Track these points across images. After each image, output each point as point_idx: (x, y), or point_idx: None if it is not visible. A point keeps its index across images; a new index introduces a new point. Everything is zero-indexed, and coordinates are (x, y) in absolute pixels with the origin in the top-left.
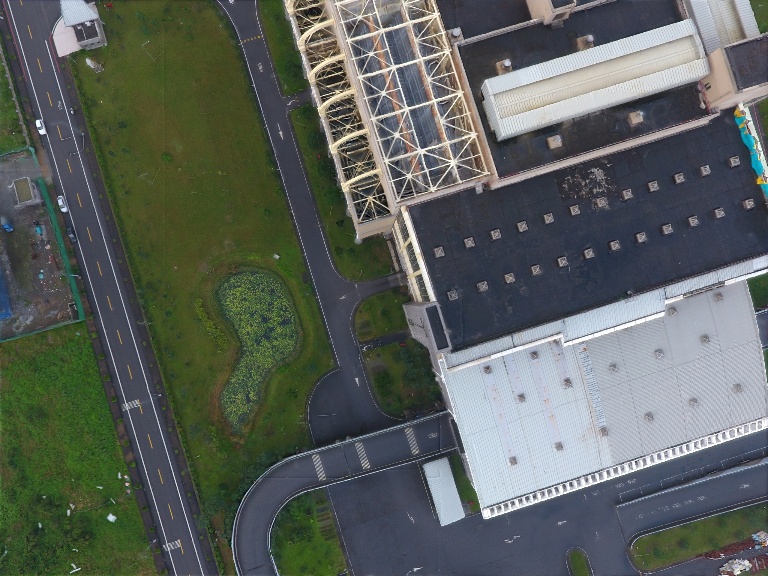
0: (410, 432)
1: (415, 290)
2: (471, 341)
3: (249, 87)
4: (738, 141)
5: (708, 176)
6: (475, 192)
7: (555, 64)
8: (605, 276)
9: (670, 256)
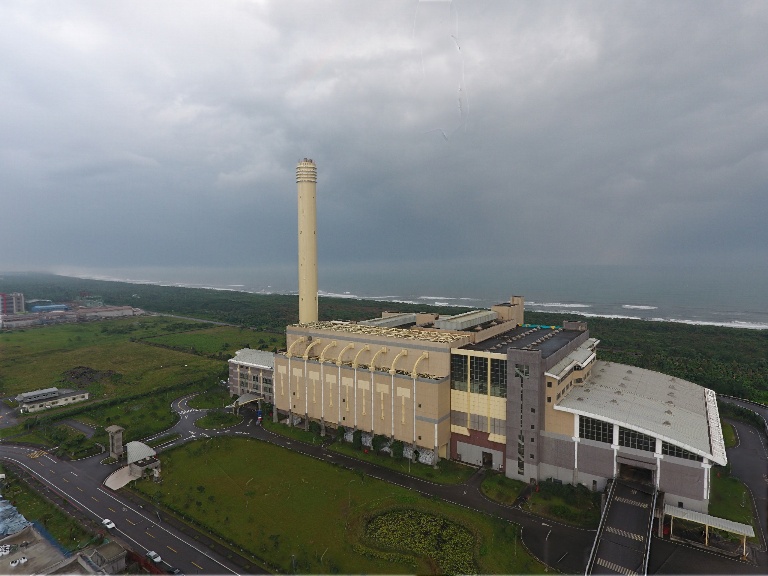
0: (620, 499)
1: (499, 417)
2: None
3: None
4: None
5: None
6: None
7: None
8: None
9: None
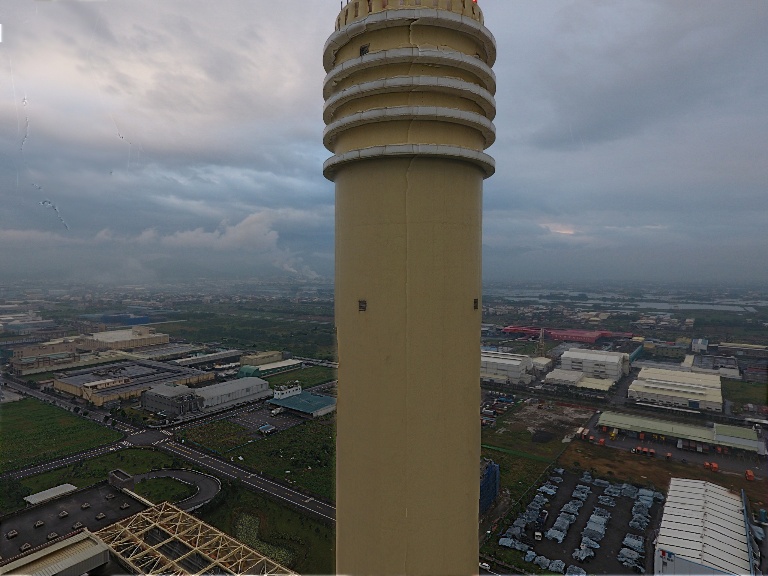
0: None
1: None
2: None
3: None
4: None
5: None
6: None
7: None
8: None
9: None
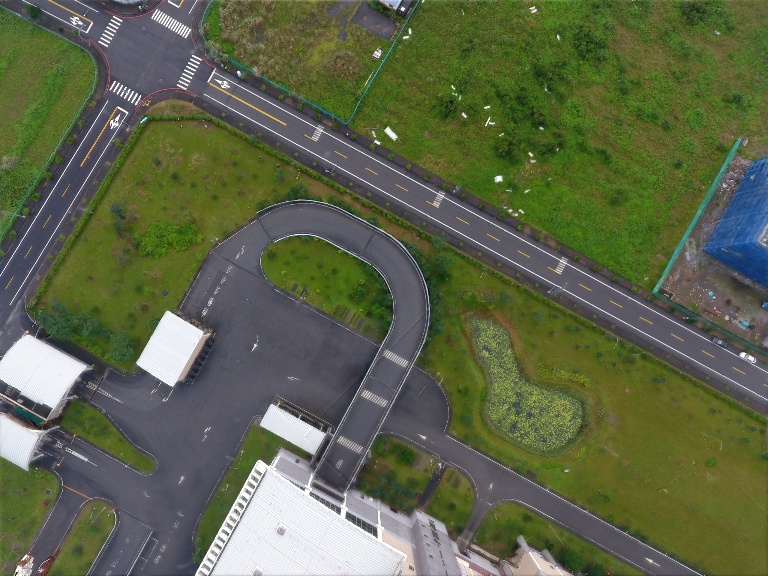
0: (358, 450)
1: None
2: None
3: (707, 573)
4: None
5: None
6: None
7: None
8: None
9: None
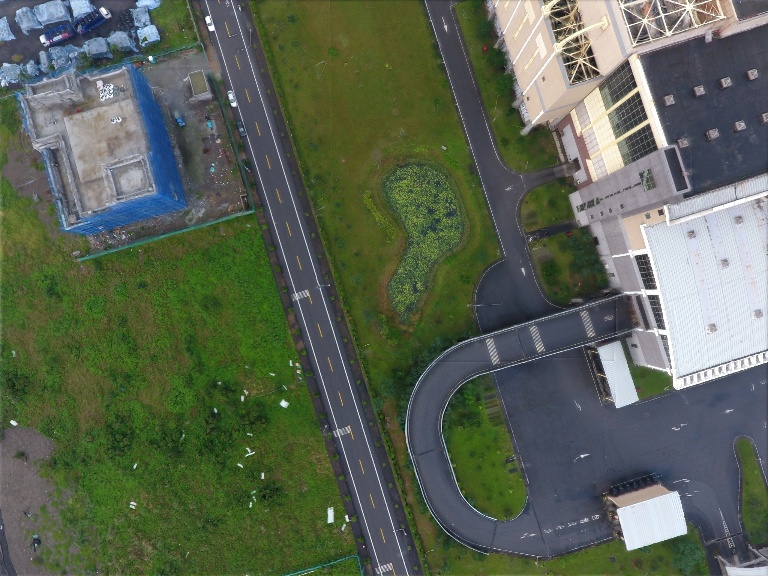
0: (586, 315)
1: (606, 164)
2: (701, 189)
3: None
4: None
5: None
6: (704, 41)
7: None
8: None
9: None
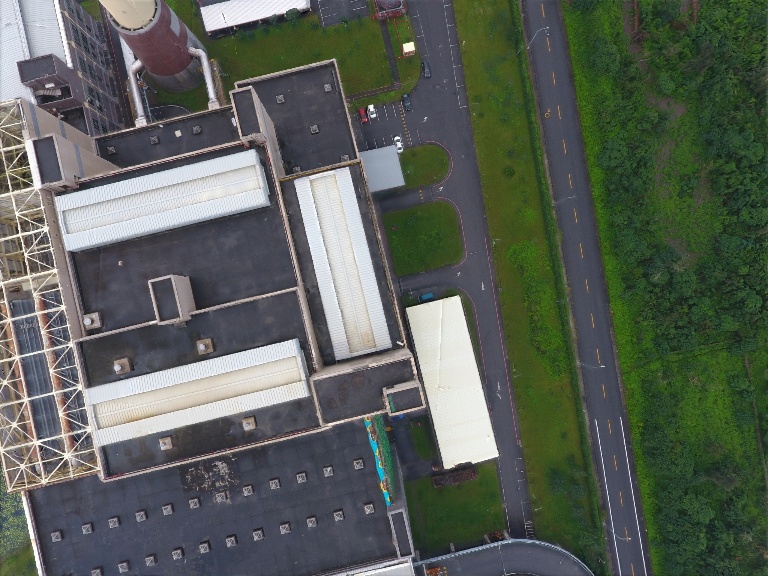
0: None
1: None
2: None
3: None
4: (365, 443)
5: (332, 477)
6: (98, 478)
7: (155, 378)
8: (220, 571)
9: (287, 555)
